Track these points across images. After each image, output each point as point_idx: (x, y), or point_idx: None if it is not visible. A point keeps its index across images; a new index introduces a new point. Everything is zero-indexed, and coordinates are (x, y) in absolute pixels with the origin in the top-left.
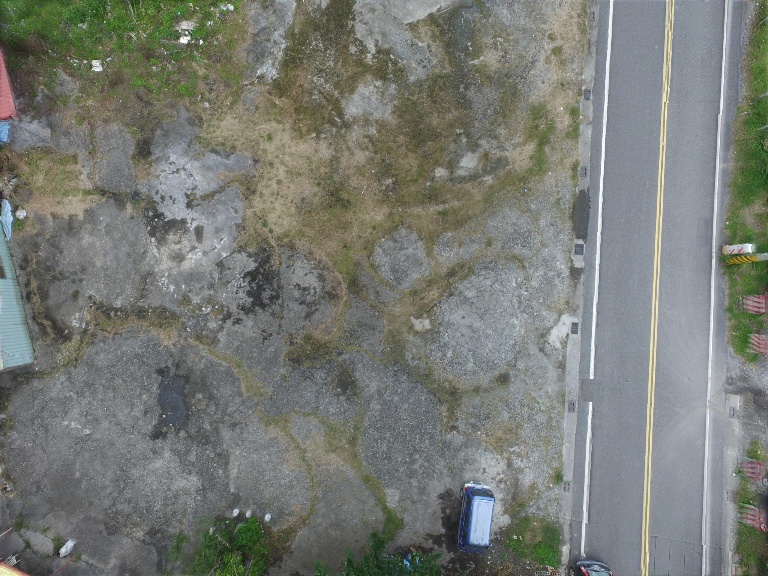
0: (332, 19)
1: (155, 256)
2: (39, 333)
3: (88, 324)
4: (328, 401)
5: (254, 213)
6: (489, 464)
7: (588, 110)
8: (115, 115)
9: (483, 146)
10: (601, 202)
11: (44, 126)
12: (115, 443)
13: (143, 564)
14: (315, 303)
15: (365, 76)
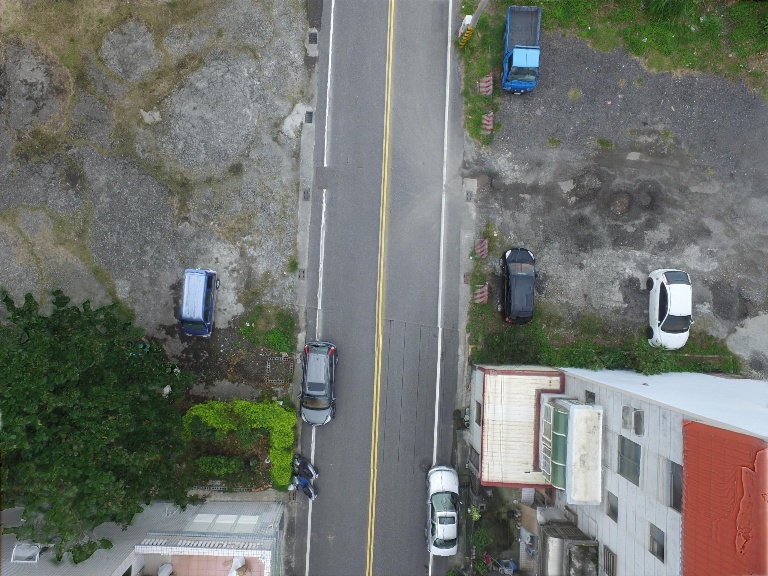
0: None
1: None
2: None
3: None
4: (57, 195)
5: None
6: (221, 253)
7: None
8: None
9: None
10: None
11: None
12: None
13: None
14: (43, 98)
15: None
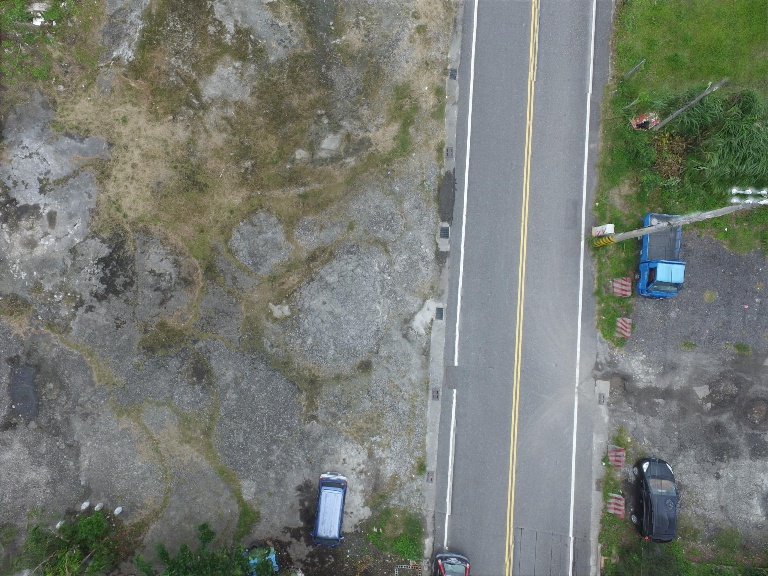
0: None
1: (6, 242)
2: None
3: None
4: (183, 390)
5: (108, 198)
6: (349, 454)
7: (454, 90)
8: None
9: (345, 127)
10: (466, 184)
11: None
12: None
13: None
14: (171, 289)
15: (224, 57)
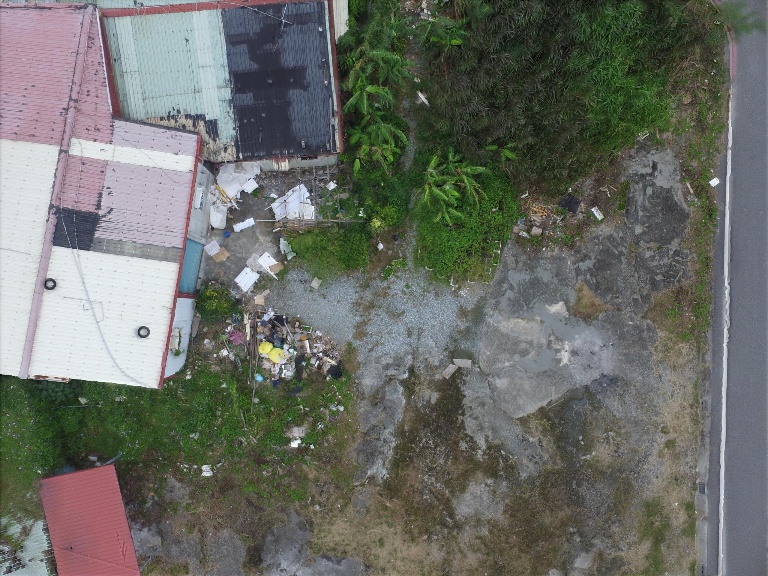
0: (442, 414)
1: None
2: None
3: None
4: None
5: None
6: None
7: (703, 504)
8: (225, 521)
9: (597, 546)
10: None
11: (154, 534)
12: None
13: None
14: None
15: (476, 474)
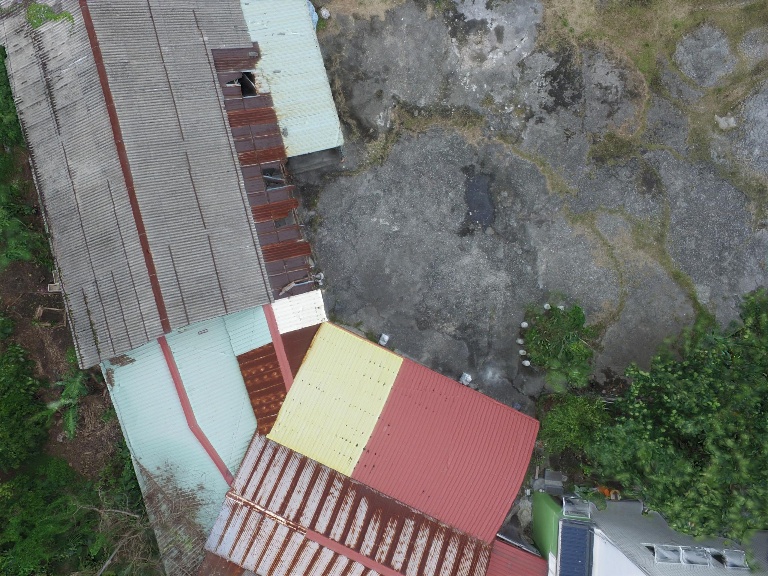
0: None
1: (456, 56)
2: (345, 132)
3: (392, 123)
4: (634, 199)
5: (554, 12)
6: None
7: None
8: None
9: None
10: None
11: None
12: (423, 239)
13: (455, 358)
14: (617, 102)
15: None
